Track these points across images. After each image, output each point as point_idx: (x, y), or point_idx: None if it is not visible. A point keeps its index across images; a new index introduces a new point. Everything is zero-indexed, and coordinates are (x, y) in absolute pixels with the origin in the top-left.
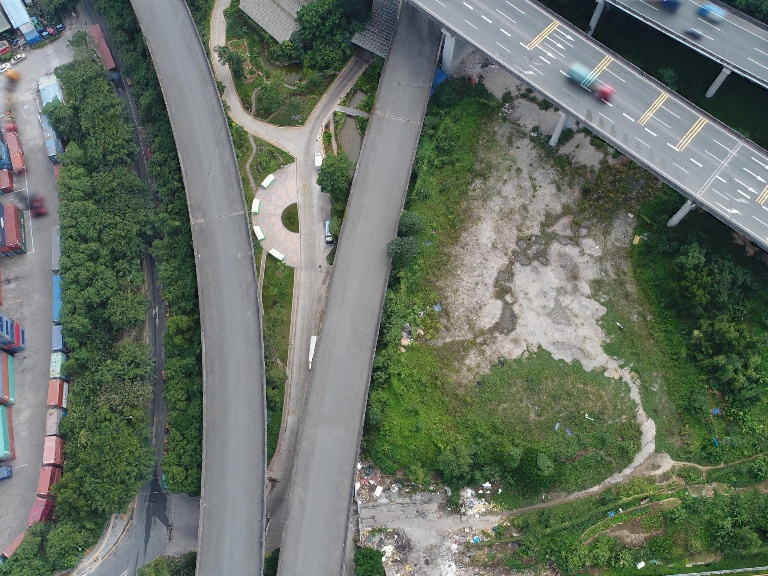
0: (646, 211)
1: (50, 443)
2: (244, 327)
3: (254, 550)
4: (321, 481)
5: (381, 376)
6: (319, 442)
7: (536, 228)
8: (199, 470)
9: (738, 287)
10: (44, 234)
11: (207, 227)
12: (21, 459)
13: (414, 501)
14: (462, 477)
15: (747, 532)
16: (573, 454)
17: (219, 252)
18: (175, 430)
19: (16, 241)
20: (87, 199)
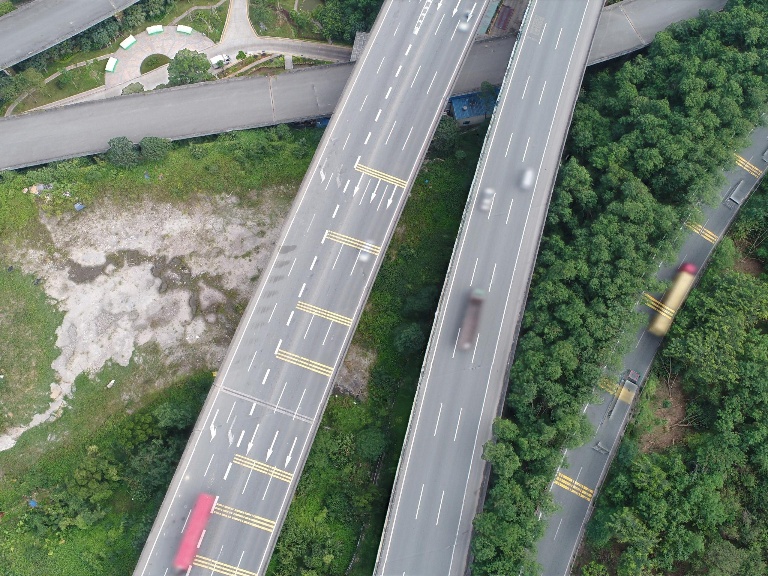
0: None
1: None
2: (4, 53)
3: None
4: None
5: None
6: None
7: (199, 270)
8: None
9: None
10: None
11: None
12: None
13: None
14: None
15: None
16: None
17: (70, 6)
18: None
19: None
20: None
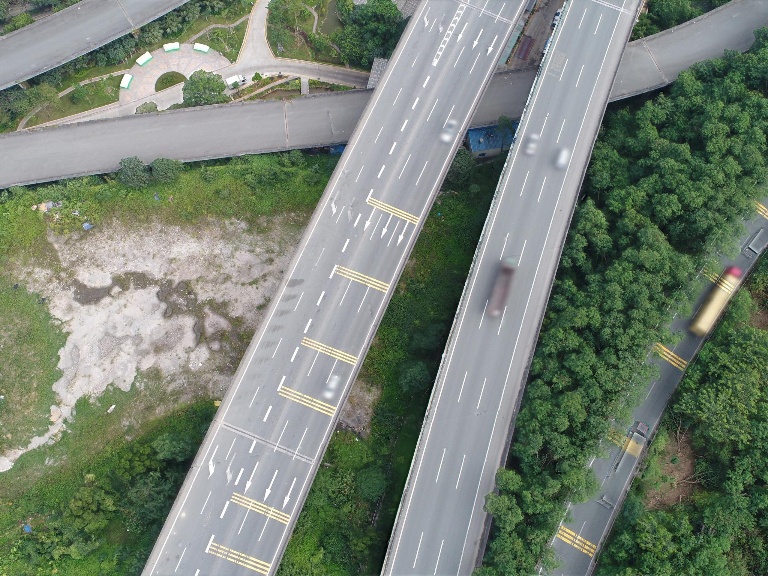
0: None
1: None
2: (19, 67)
3: None
4: None
5: (3, 196)
6: None
7: (206, 296)
8: None
9: None
10: None
11: (110, 3)
12: None
13: None
14: None
15: None
16: None
17: (87, 21)
18: None
19: None
20: None
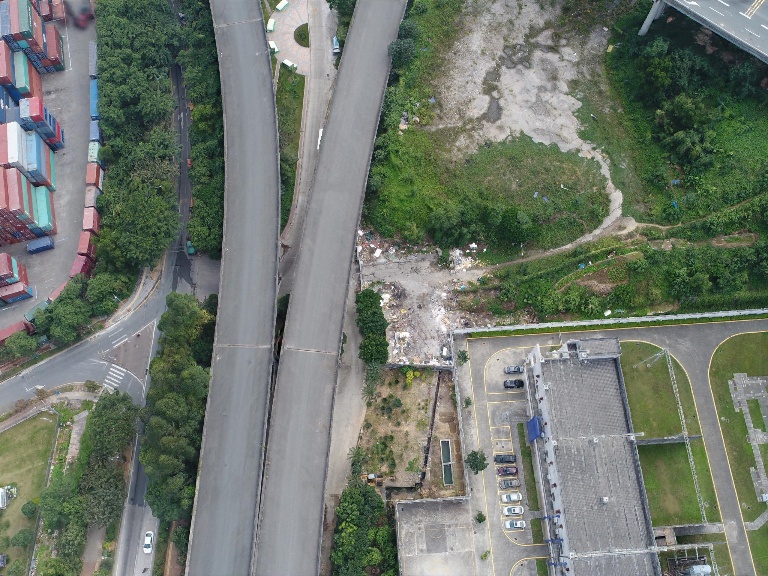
0: (619, 25)
1: (89, 213)
2: (261, 111)
3: (269, 284)
4: (328, 235)
5: (381, 153)
6: (326, 204)
7: (521, 39)
8: (221, 229)
9: (697, 75)
10: (80, 55)
11: (228, 31)
12: (62, 234)
13: (409, 260)
14: (451, 235)
15: (699, 274)
16: (549, 216)
17: (239, 51)
18: (199, 200)
19: (57, 55)
20: (120, 17)
